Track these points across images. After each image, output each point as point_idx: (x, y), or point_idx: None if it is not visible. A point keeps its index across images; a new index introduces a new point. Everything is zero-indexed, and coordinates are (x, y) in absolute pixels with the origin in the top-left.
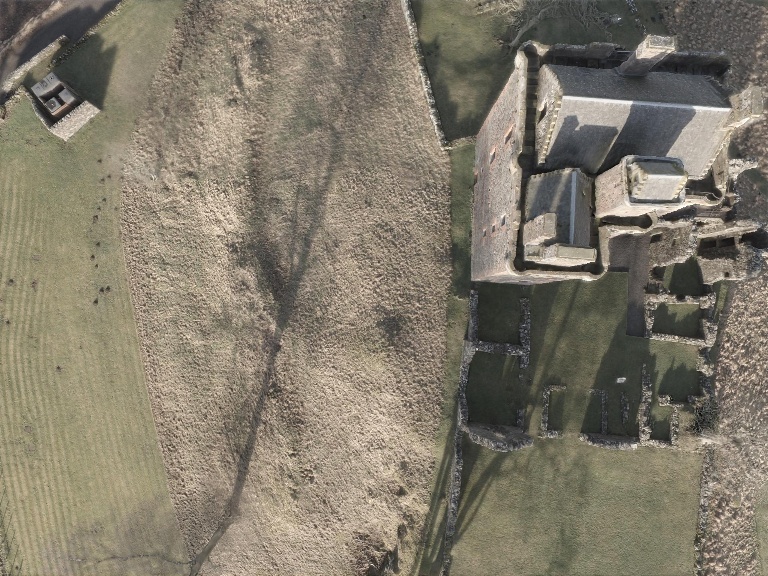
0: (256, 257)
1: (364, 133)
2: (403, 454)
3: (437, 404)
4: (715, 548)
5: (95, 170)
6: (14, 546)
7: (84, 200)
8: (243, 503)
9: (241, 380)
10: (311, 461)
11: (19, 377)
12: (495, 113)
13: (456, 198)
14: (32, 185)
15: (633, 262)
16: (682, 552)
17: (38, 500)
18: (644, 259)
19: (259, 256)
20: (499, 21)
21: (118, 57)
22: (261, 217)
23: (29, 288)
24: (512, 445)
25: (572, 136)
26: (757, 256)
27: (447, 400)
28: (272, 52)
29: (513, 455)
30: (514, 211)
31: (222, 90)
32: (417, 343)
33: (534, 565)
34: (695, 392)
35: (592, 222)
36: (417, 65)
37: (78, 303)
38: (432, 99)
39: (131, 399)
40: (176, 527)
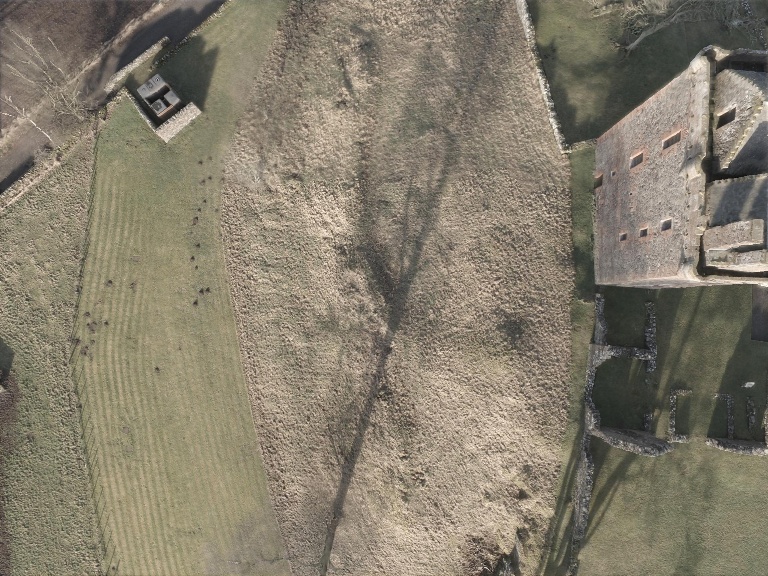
0: (366, 259)
1: (480, 136)
2: (526, 458)
3: (563, 408)
4: None
5: (196, 171)
6: (111, 547)
7: (184, 201)
8: (348, 505)
9: (347, 382)
10: (423, 464)
11: (117, 378)
12: (639, 117)
13: (576, 201)
14: (132, 186)
15: None
16: None
17: (135, 501)
18: None
19: (369, 258)
20: (615, 24)
21: (220, 59)
22: (370, 219)
23: (128, 289)
24: (657, 450)
25: (762, 141)
26: None
27: (573, 404)
28: (381, 54)
29: (639, 459)
30: (697, 216)
31: (329, 92)
32: (540, 347)
33: (659, 570)
34: None
35: None
36: (535, 68)
37: (177, 304)
38: (551, 102)
39: (230, 400)
40: (276, 529)
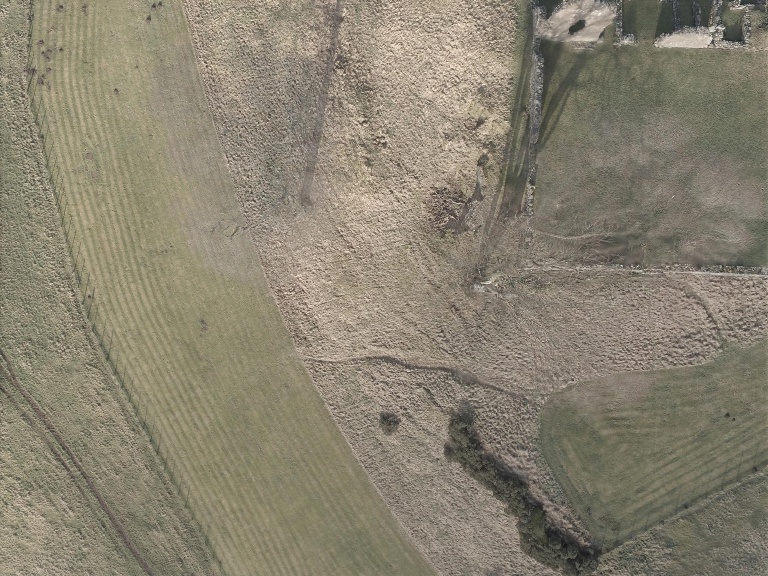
0: None
1: None
2: (480, 80)
3: (512, 19)
4: None
5: None
6: (85, 275)
7: None
8: (314, 193)
9: (304, 67)
10: (383, 126)
11: (77, 104)
12: None
13: None
14: None
15: None
16: (761, 149)
17: (105, 226)
18: None
19: None
20: None
21: None
22: None
23: (80, 12)
24: None
25: None
26: None
27: (521, 15)
28: None
29: (590, 65)
30: None
31: None
32: None
33: (617, 174)
34: None
35: None
36: None
37: (131, 22)
38: None
39: (192, 114)
40: (247, 235)
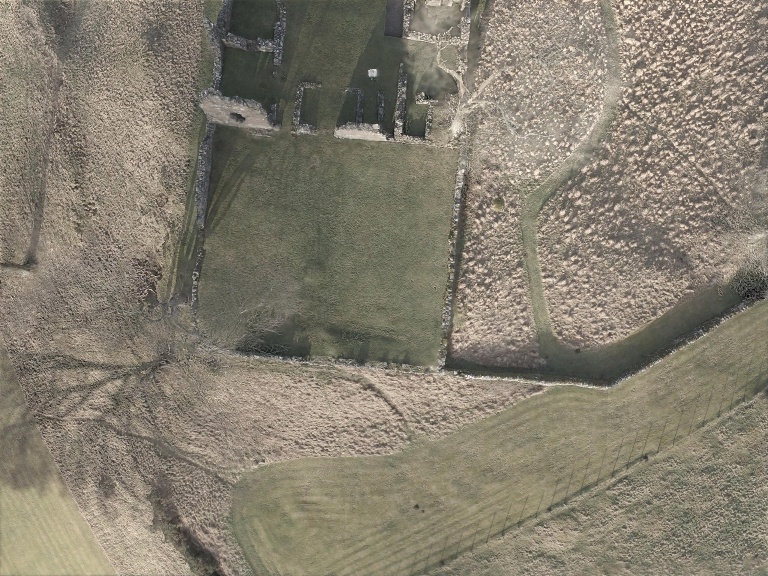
0: None
1: None
2: (163, 159)
3: (191, 101)
4: (475, 249)
5: None
6: None
7: None
8: (39, 252)
9: (33, 126)
10: (93, 193)
11: None
12: None
13: None
14: None
15: None
16: (436, 247)
17: None
18: None
19: None
20: None
21: None
22: None
23: None
24: None
25: None
26: None
27: None
28: None
29: (267, 152)
30: None
31: None
32: (175, 47)
33: (290, 263)
34: (453, 92)
35: None
36: None
37: None
38: None
39: None
40: None
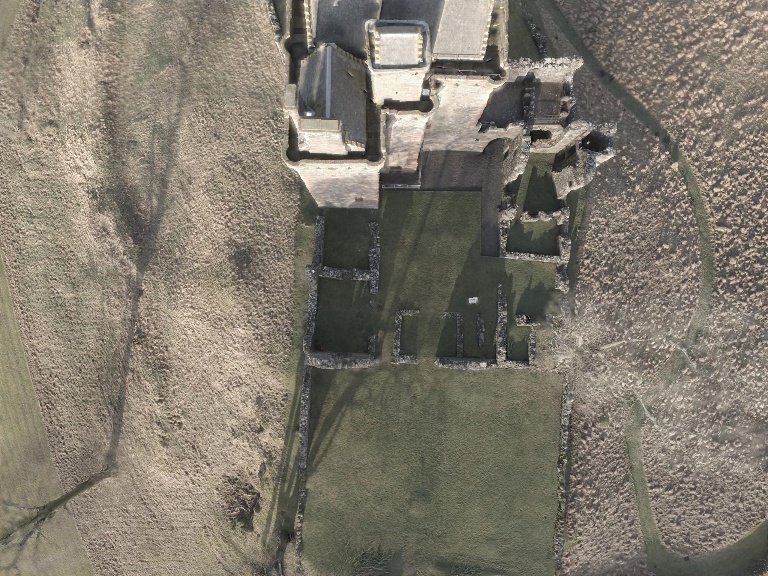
0: (115, 201)
1: (212, 65)
2: (258, 389)
3: (286, 334)
4: (582, 470)
5: None
6: None
7: None
8: (120, 456)
9: (110, 330)
10: (178, 406)
11: None
12: None
13: None
14: None
15: (486, 181)
16: (545, 474)
17: None
18: (497, 177)
19: (118, 200)
20: None
21: None
22: (120, 161)
23: None
24: (341, 363)
25: (333, 13)
26: (591, 158)
27: (296, 330)
28: None
29: (367, 383)
30: None
31: (76, 33)
32: (267, 274)
33: (394, 495)
34: (554, 311)
35: (373, 110)
36: None
37: None
38: (276, 25)
39: (7, 358)
40: (59, 486)
